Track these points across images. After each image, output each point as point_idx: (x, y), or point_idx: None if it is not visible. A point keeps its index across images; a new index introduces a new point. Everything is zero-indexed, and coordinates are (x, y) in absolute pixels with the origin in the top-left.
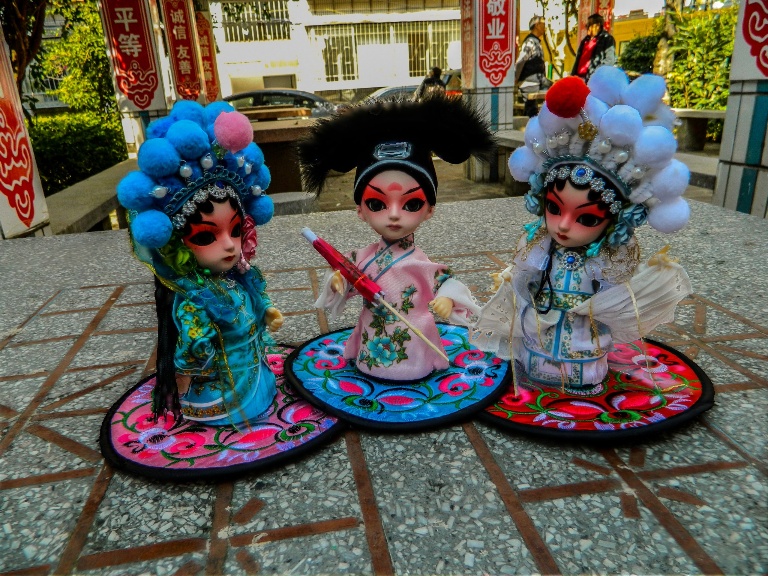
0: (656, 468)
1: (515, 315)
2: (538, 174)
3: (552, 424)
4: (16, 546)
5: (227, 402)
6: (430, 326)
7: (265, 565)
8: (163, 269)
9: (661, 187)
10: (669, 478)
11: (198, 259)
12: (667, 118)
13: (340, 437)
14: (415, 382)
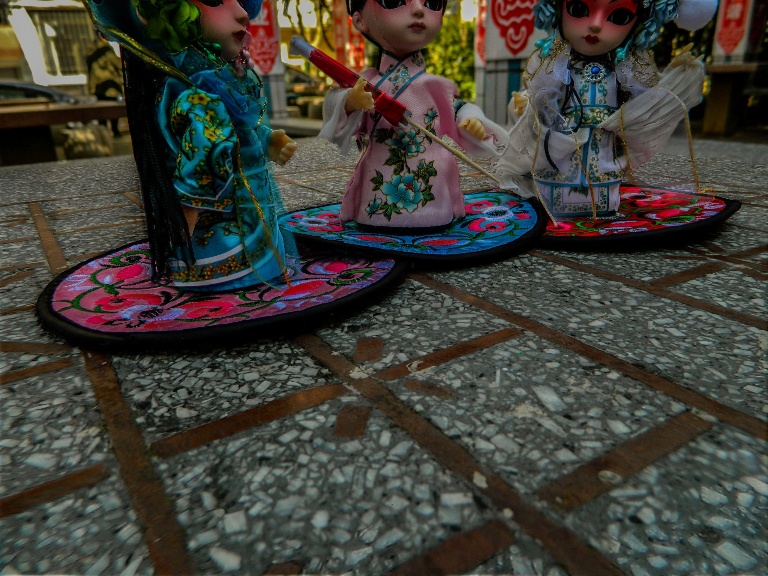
0: (737, 251)
1: (534, 144)
2: None
3: None
4: (5, 461)
5: (248, 251)
6: (452, 160)
7: (455, 385)
8: (143, 44)
9: None
10: (757, 254)
11: (202, 26)
12: None
13: (405, 278)
14: (441, 230)
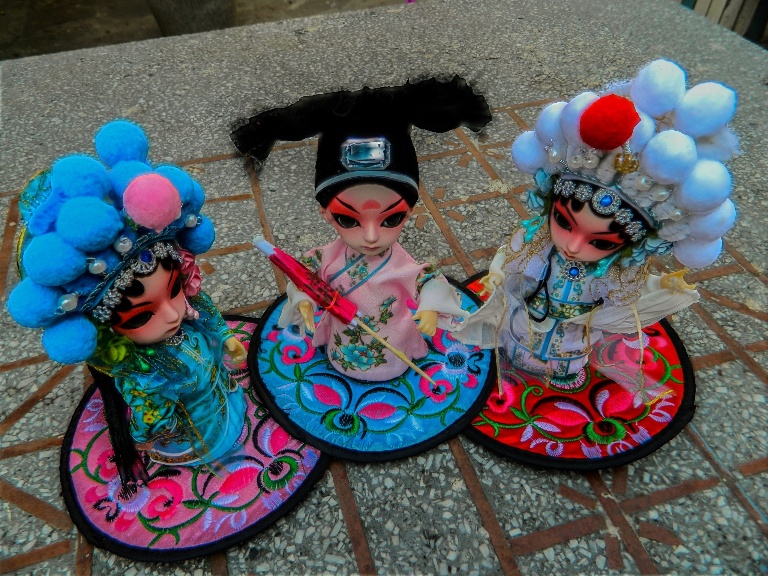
0: (637, 494)
1: (503, 311)
2: (548, 173)
3: (540, 447)
4: None
5: (198, 450)
6: (410, 329)
7: None
8: None
9: (700, 234)
10: (649, 509)
11: (136, 341)
12: (727, 147)
13: (325, 471)
14: (394, 378)
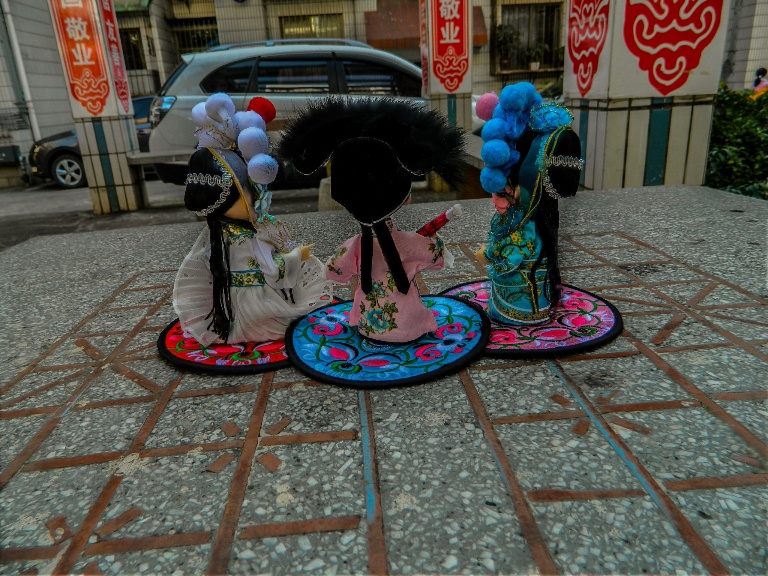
0: None
1: None
2: None
3: None
4: None
5: None
6: None
7: None
8: None
9: None
10: None
11: None
12: None
13: None
14: None
